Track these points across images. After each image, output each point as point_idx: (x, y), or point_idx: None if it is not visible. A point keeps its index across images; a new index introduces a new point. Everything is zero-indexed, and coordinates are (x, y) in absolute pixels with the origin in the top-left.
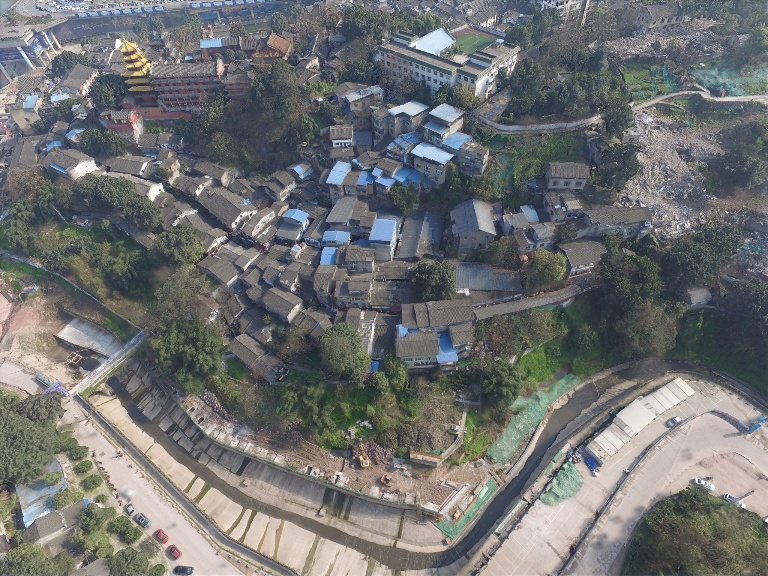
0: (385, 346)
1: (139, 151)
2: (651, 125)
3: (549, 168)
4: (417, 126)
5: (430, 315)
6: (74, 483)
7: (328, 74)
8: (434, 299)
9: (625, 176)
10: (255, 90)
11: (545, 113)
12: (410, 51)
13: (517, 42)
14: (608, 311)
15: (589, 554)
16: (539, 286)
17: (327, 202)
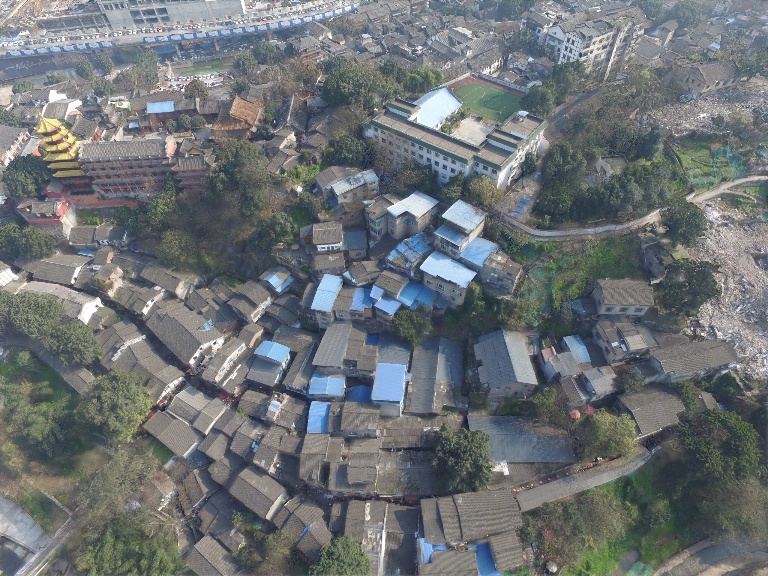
0: (401, 564)
1: (72, 248)
2: (717, 222)
3: (599, 288)
4: (424, 225)
5: (462, 522)
6: None
7: (308, 156)
8: (464, 488)
9: (699, 301)
10: (215, 182)
11: (588, 213)
12: (411, 126)
13: (539, 107)
14: (685, 480)
15: None
16: (596, 452)
17: (312, 324)
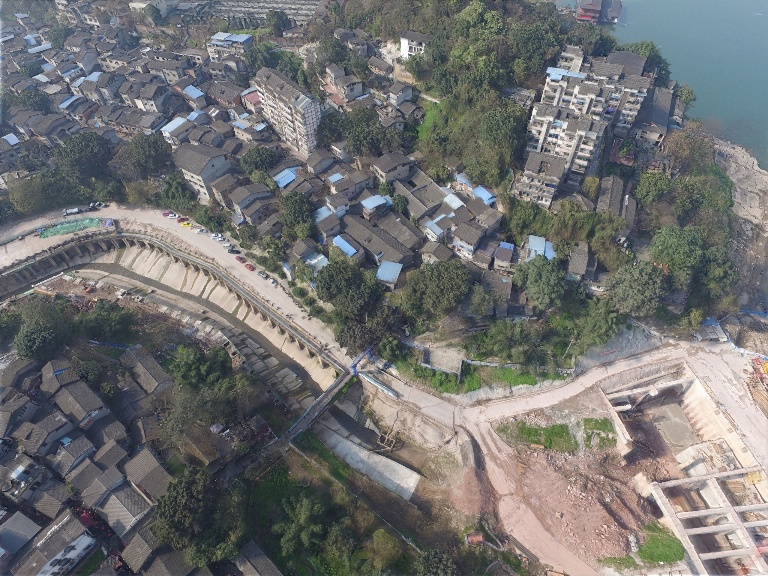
0: (4, 347)
1: None
2: None
3: None
4: None
5: None
6: (311, 290)
7: None
8: None
9: None
10: None
11: None
12: None
13: None
14: None
15: None
16: None
17: None
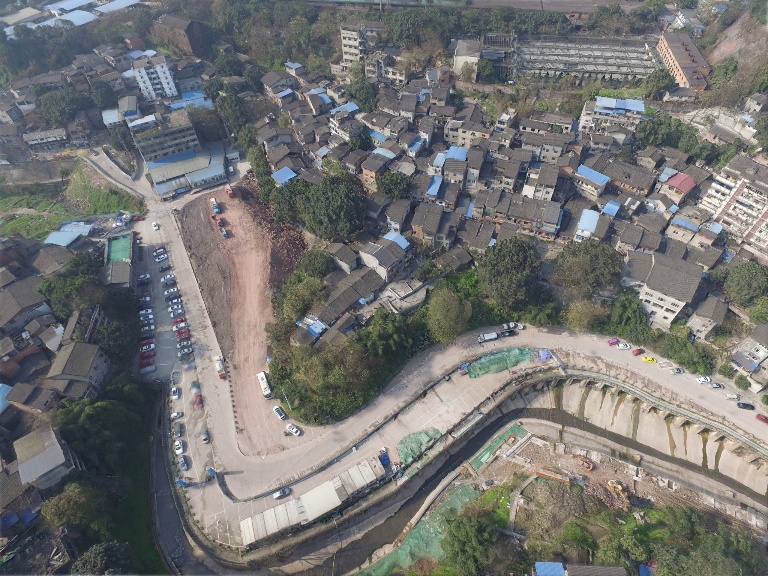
0: None
1: None
2: None
3: None
4: None
5: None
6: None
7: None
8: None
9: None
10: None
11: None
12: None
13: None
14: None
15: (413, 391)
16: None
17: None
